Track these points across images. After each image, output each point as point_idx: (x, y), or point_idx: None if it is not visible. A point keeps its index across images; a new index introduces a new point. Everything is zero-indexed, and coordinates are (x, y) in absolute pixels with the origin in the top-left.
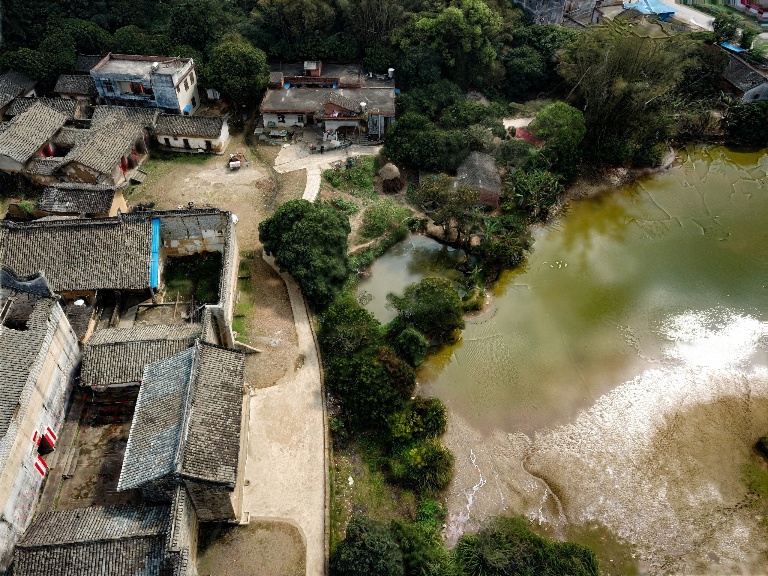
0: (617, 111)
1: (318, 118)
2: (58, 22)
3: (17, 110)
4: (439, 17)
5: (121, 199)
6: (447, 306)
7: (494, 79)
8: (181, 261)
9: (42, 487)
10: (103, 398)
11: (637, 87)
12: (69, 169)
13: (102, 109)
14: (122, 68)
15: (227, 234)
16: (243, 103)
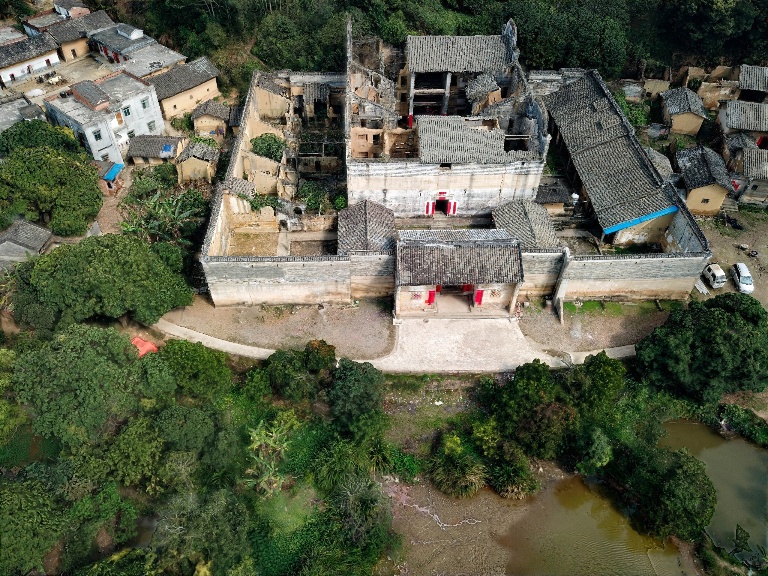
0: None
1: None
2: None
3: None
4: None
5: (720, 196)
6: (654, 481)
7: None
8: None
9: (420, 216)
10: None
11: None
12: (740, 155)
13: None
14: None
15: (671, 253)
16: None
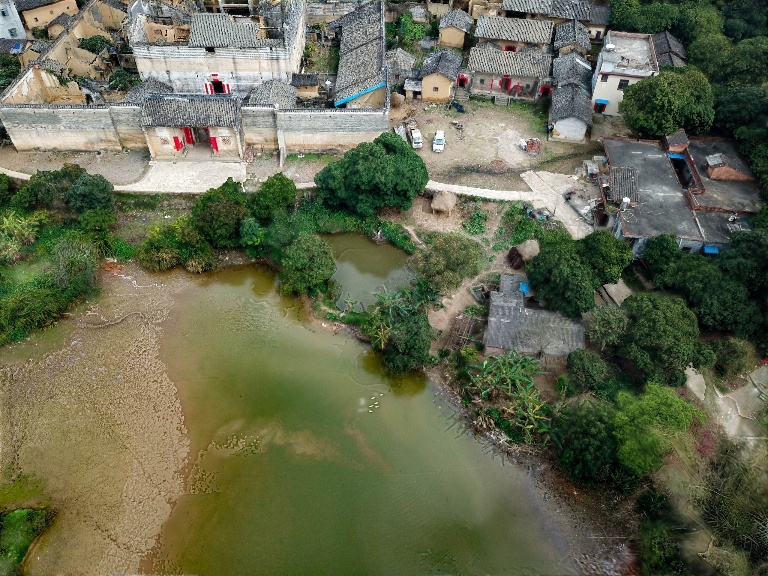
0: None
1: (598, 175)
2: None
3: (562, 26)
4: None
5: (445, 85)
6: (274, 246)
7: None
8: None
9: None
10: None
11: None
12: None
13: (571, 56)
14: (630, 46)
15: None
16: None
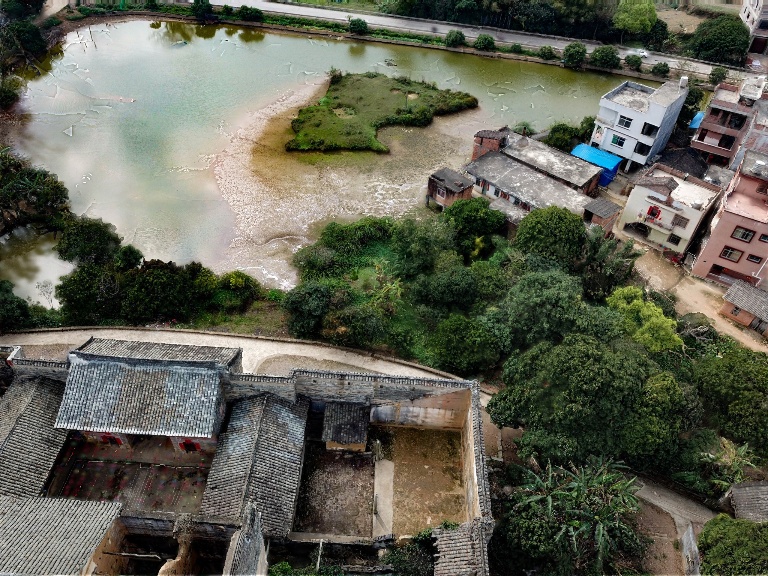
0: None
1: None
2: None
3: None
4: None
5: None
6: (109, 223)
7: None
8: None
9: None
10: None
11: None
12: None
13: None
14: None
15: None
16: None
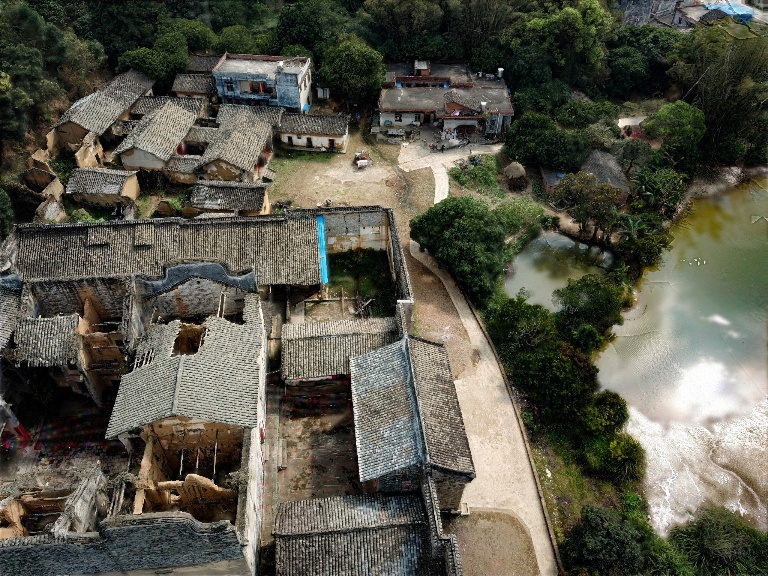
0: (735, 110)
1: (439, 117)
2: (167, 22)
3: (142, 109)
4: (552, 17)
5: (266, 197)
6: (616, 302)
7: (599, 79)
8: (335, 258)
9: (263, 478)
10: (295, 392)
11: (764, 87)
12: (211, 167)
13: (227, 108)
14: (241, 67)
15: (396, 231)
16: (355, 102)
